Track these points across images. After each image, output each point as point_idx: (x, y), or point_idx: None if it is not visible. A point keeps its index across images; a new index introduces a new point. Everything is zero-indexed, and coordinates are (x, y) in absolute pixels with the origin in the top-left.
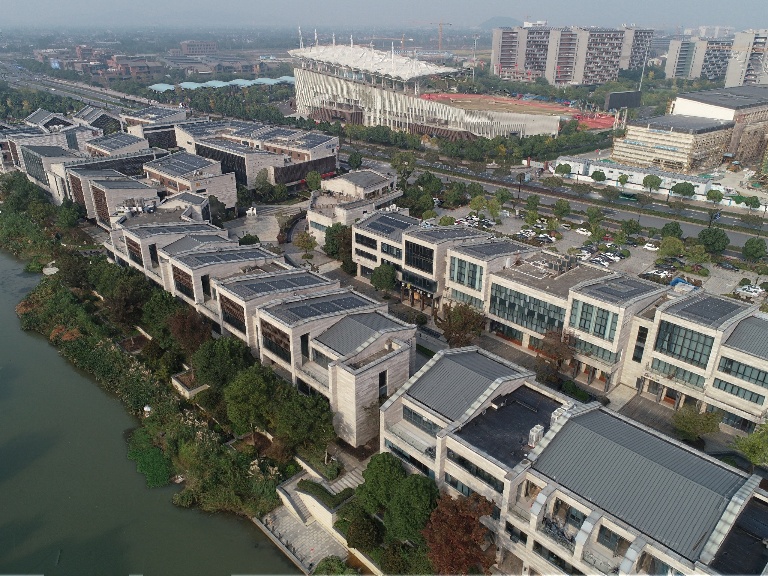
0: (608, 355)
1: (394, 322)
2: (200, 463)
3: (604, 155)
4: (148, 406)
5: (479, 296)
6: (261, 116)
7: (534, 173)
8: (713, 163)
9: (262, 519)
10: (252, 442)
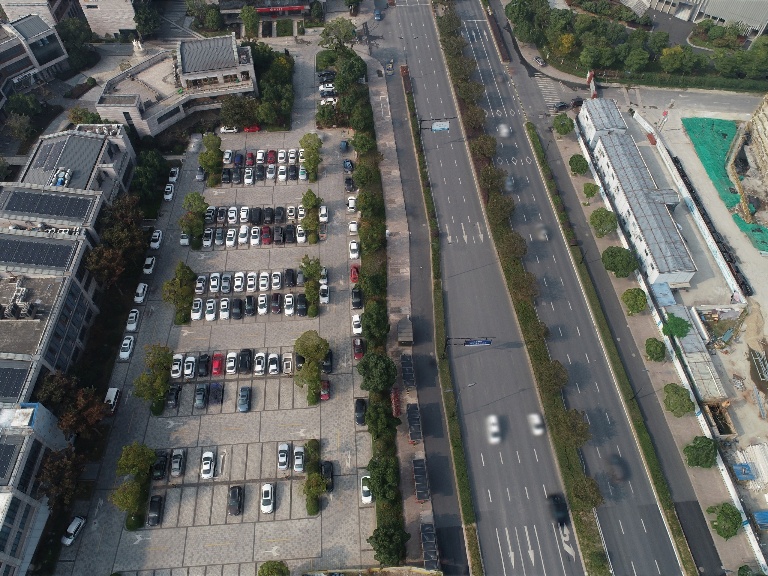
0: None
1: None
2: None
3: None
4: None
5: None
6: None
7: None
8: None
9: None
10: None
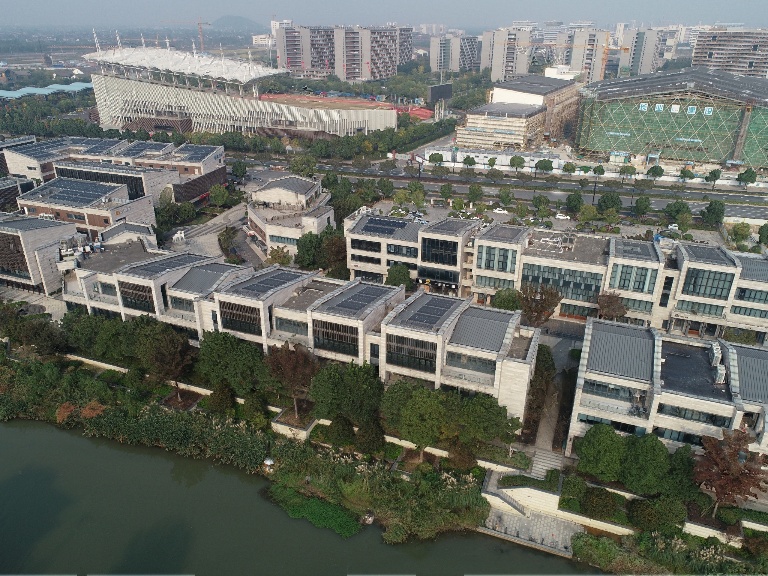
0: (644, 306)
1: (496, 312)
2: (385, 496)
3: (447, 143)
4: (270, 459)
5: (512, 278)
6: (71, 131)
7: (406, 165)
8: (539, 142)
9: (486, 526)
10: (417, 460)
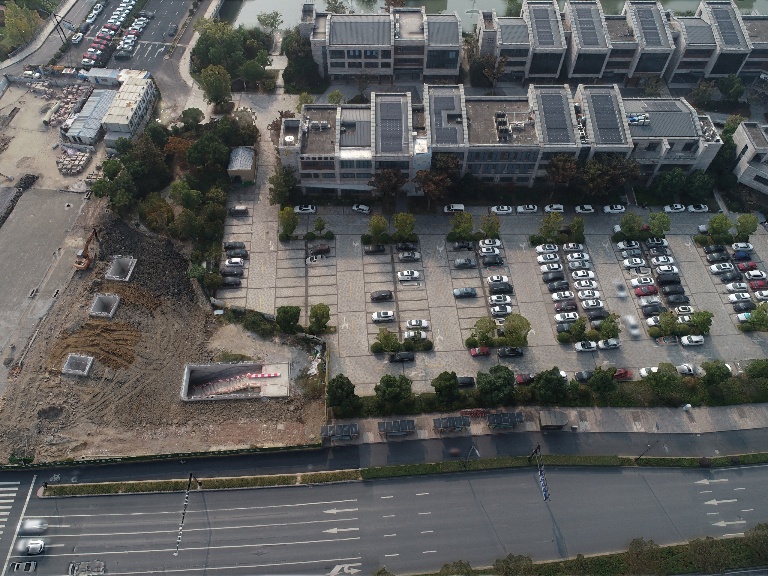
0: None
1: None
2: None
3: None
4: None
5: None
6: None
7: None
8: None
9: None
10: None
